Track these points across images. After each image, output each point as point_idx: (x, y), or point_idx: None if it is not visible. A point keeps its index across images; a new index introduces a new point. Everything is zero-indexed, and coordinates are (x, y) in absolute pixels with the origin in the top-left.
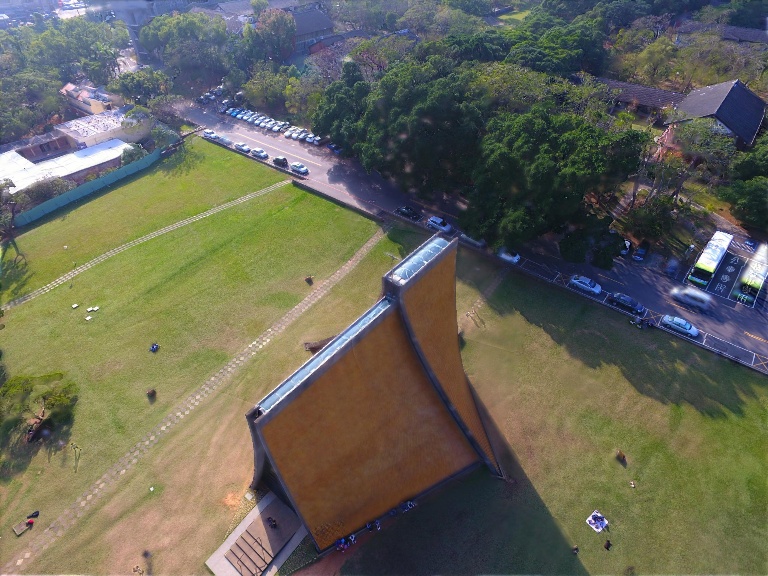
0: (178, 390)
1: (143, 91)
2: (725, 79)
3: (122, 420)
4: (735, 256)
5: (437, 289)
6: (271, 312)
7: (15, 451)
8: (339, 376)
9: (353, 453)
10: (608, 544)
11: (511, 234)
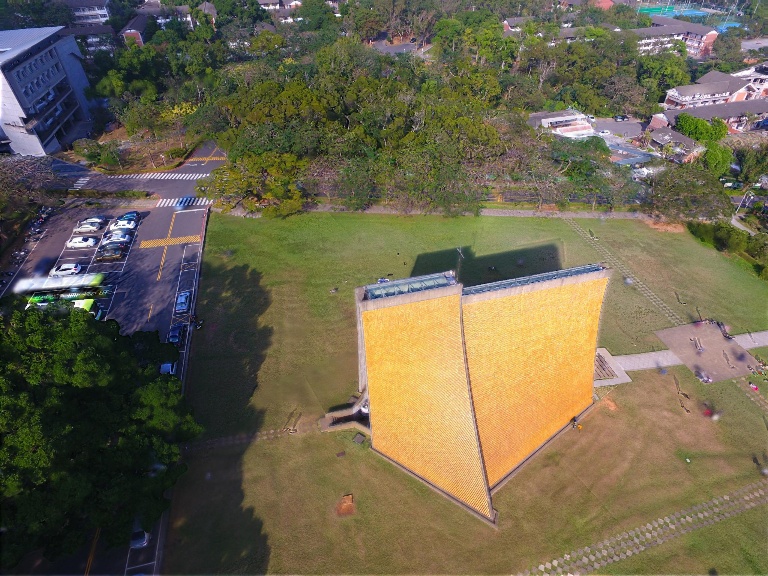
0: (678, 567)
1: None
2: None
3: (752, 571)
4: None
5: None
6: None
7: None
8: None
9: None
10: (390, 274)
11: (177, 406)
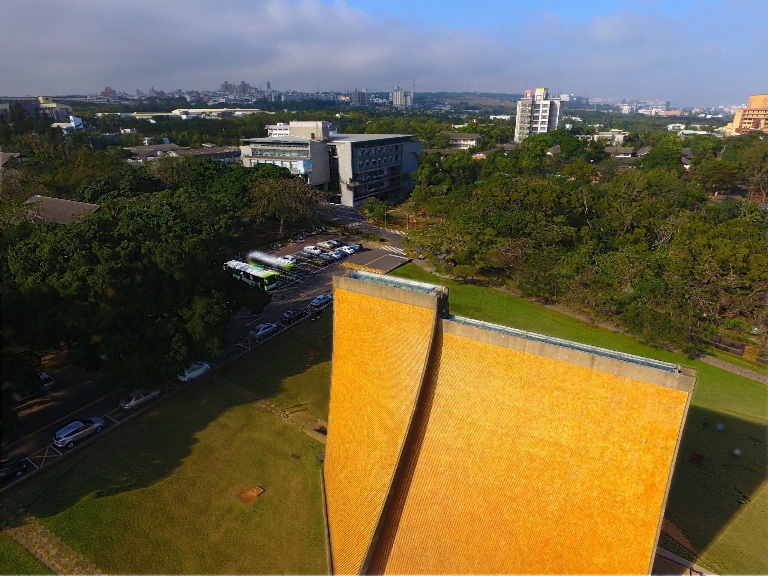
0: None
1: None
2: (19, 200)
3: None
4: None
5: None
6: None
7: None
8: None
9: None
10: None
11: (213, 327)
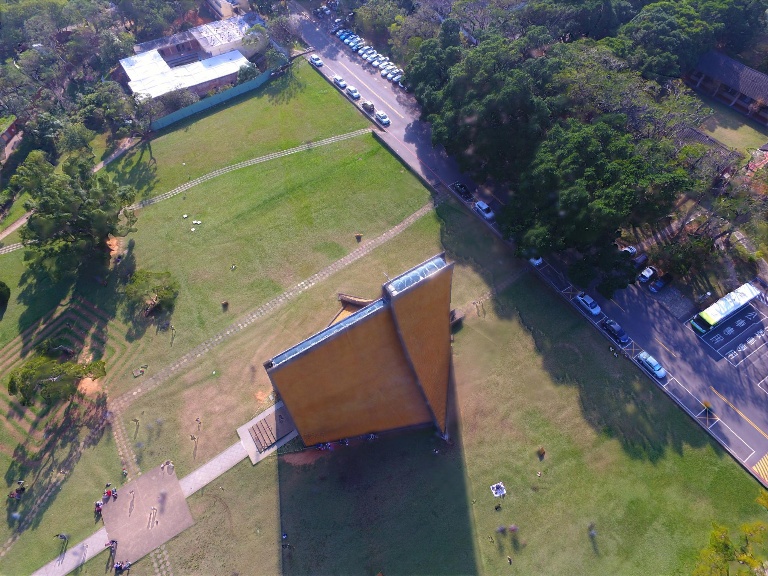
0: (243, 306)
1: (266, 2)
2: None
3: (204, 318)
4: (755, 311)
5: (429, 297)
6: (321, 259)
7: (138, 320)
8: (334, 348)
9: (337, 396)
10: (498, 506)
11: (532, 245)
